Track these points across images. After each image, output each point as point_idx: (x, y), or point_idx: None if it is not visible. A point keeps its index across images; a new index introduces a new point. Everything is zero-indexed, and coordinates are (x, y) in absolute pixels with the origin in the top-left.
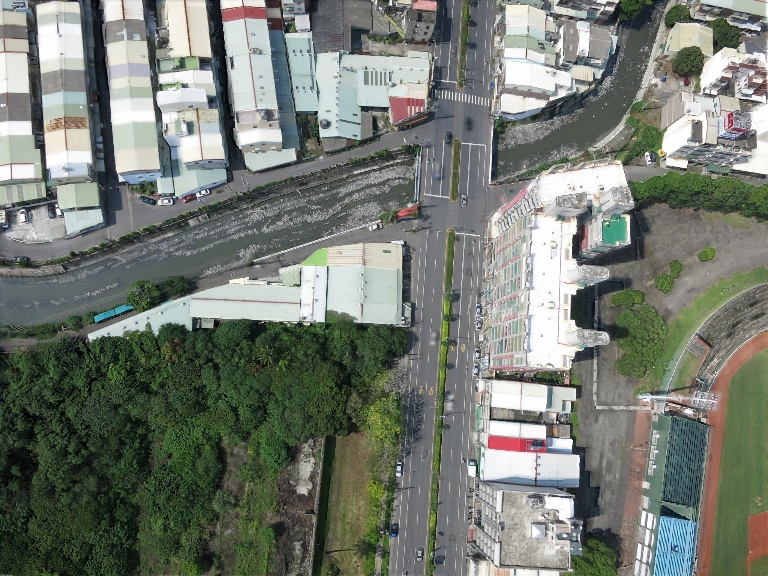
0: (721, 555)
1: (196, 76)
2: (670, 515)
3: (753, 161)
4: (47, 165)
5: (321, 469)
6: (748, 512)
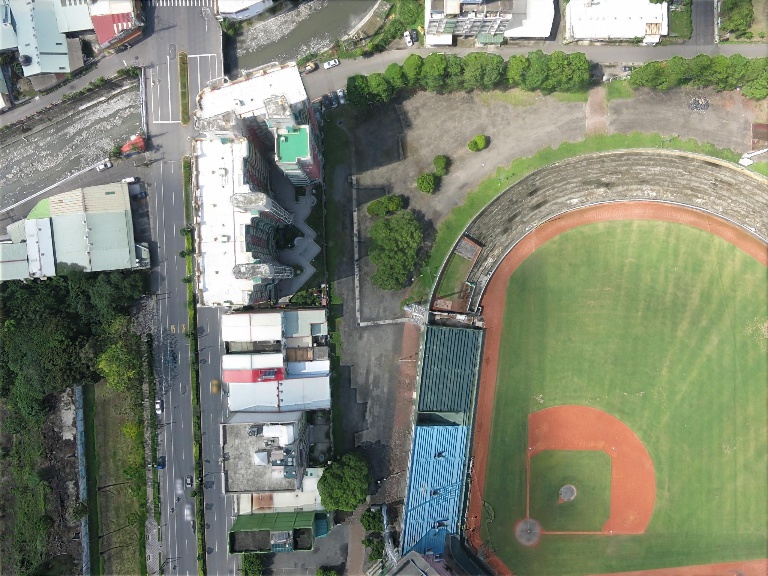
0: (498, 454)
1: None
2: (435, 423)
3: (529, 23)
4: None
5: (75, 416)
6: (528, 410)
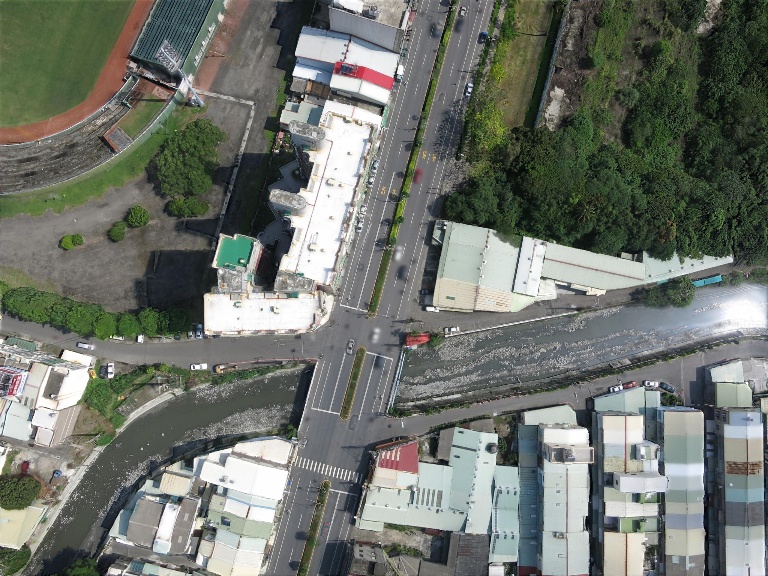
0: None
1: (623, 510)
2: None
3: None
4: (763, 427)
5: None
6: None
